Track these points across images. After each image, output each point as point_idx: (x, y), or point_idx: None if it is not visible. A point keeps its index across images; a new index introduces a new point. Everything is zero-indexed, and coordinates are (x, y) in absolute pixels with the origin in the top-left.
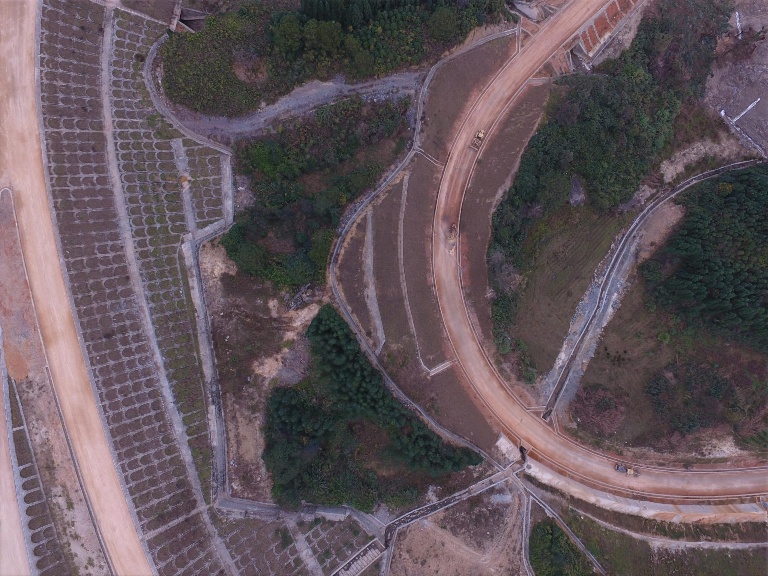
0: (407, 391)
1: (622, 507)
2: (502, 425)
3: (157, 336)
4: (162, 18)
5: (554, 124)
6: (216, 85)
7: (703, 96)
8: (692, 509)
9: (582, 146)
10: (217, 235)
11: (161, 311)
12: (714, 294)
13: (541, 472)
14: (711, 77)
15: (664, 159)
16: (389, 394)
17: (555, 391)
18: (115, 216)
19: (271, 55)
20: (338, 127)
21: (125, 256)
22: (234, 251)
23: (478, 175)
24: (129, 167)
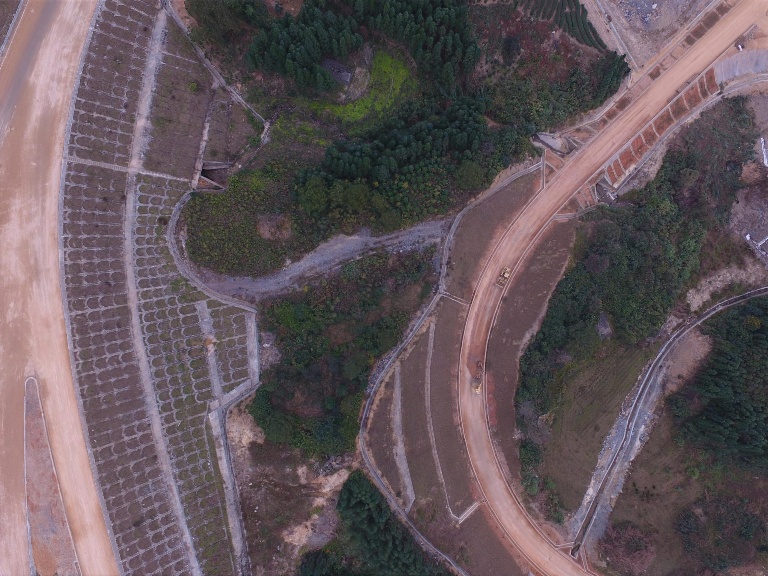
0: (437, 544)
1: None
2: (531, 564)
3: (186, 515)
4: (184, 175)
5: (582, 270)
6: (241, 249)
7: (728, 222)
8: None
9: (610, 289)
10: (243, 398)
11: (189, 488)
12: (745, 439)
13: None
14: (736, 203)
15: (690, 288)
16: (420, 554)
17: (583, 525)
18: (141, 393)
19: (296, 211)
20: (364, 281)
21: (152, 434)
22: (262, 419)
23: (504, 313)
24: (154, 339)
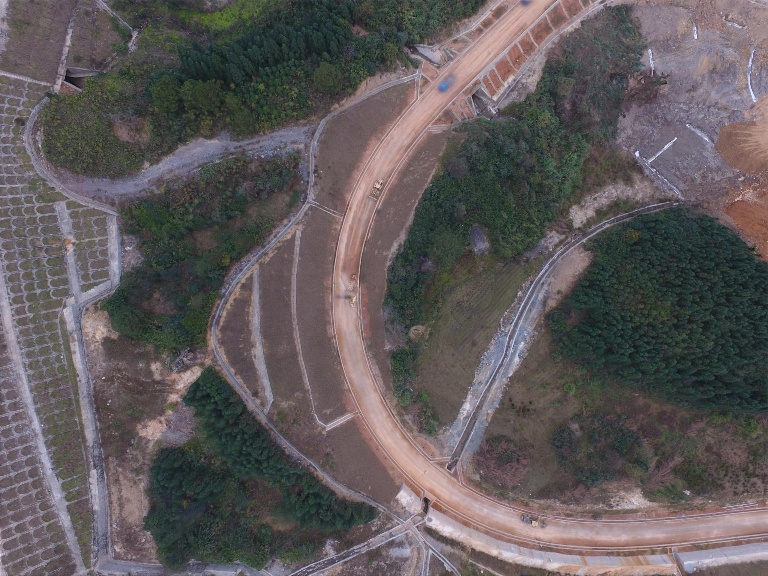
0: (300, 448)
1: (525, 560)
2: (405, 476)
3: (35, 403)
4: (45, 79)
5: (447, 176)
6: (95, 149)
7: (615, 137)
8: (599, 561)
9: (478, 197)
10: (102, 297)
11: (40, 378)
12: (613, 348)
13: (442, 525)
14: (623, 118)
15: (573, 204)
16: (277, 454)
17: (461, 441)
18: None
19: (154, 114)
20: (224, 185)
21: (2, 324)
22: None
23: (377, 225)
24: (7, 234)
